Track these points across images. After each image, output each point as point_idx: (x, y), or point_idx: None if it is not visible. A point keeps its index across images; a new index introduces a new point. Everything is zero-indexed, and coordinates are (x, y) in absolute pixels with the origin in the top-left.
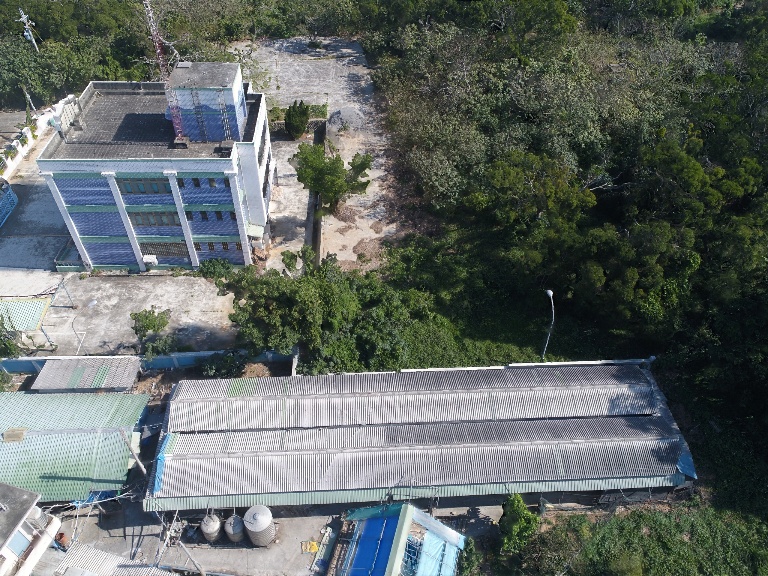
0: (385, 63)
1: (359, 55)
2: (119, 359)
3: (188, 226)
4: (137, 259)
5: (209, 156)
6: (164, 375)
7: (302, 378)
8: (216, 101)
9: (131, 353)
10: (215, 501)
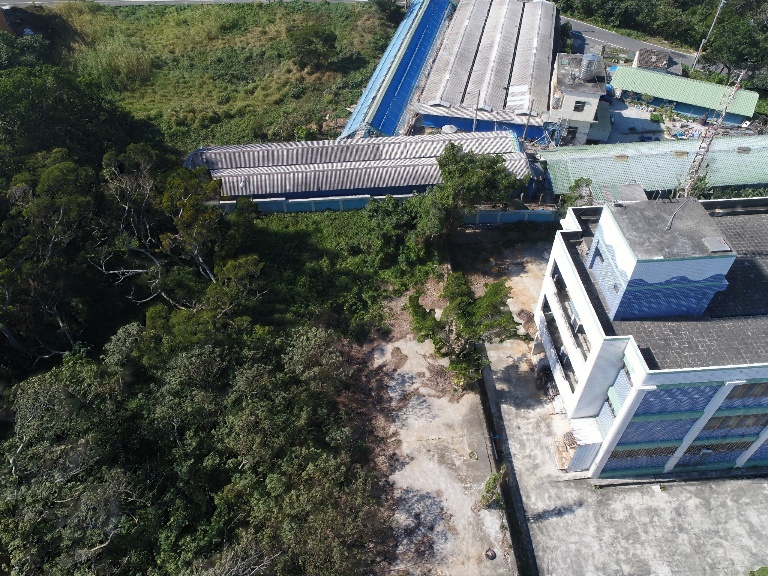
0: None
1: None
2: None
3: None
4: None
5: None
6: None
7: None
8: None
9: None
10: None
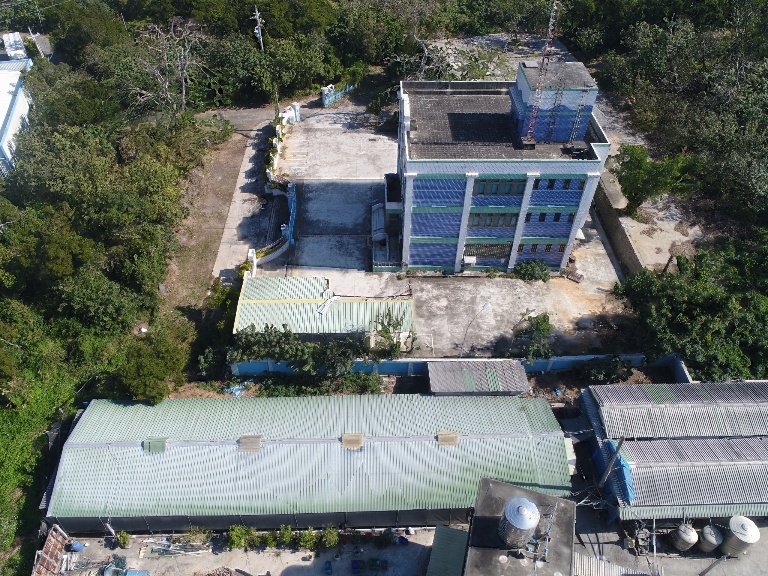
0: (618, 61)
1: (565, 53)
2: (499, 362)
3: (522, 228)
4: (456, 260)
5: (561, 157)
6: (537, 379)
7: (712, 385)
8: (577, 101)
9: (488, 356)
10: (690, 510)
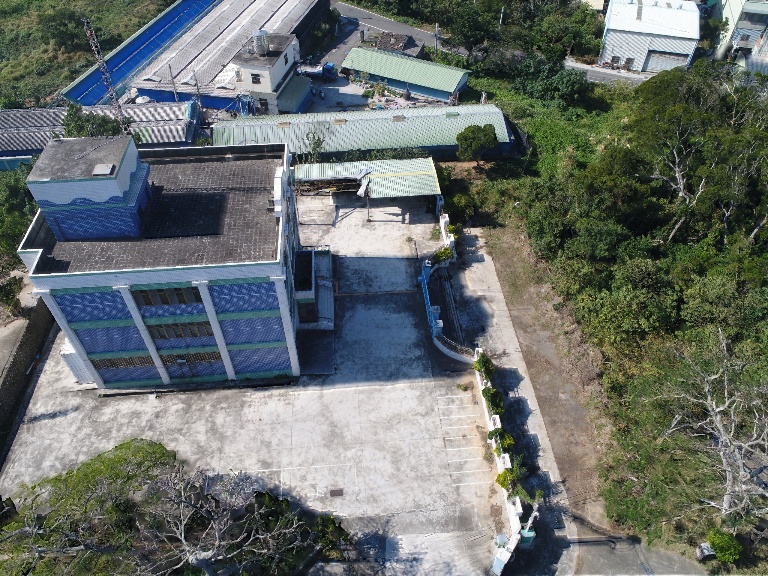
0: None
1: None
2: None
3: None
4: None
5: None
6: None
7: None
8: None
9: None
10: None
